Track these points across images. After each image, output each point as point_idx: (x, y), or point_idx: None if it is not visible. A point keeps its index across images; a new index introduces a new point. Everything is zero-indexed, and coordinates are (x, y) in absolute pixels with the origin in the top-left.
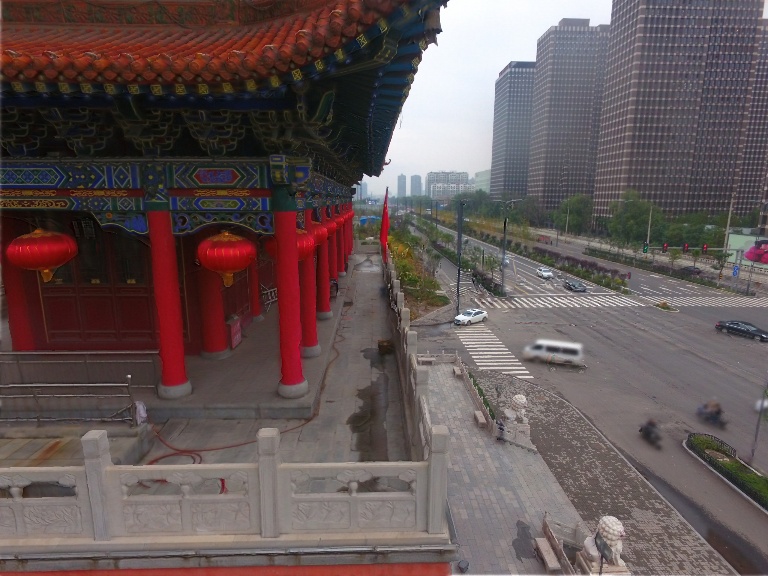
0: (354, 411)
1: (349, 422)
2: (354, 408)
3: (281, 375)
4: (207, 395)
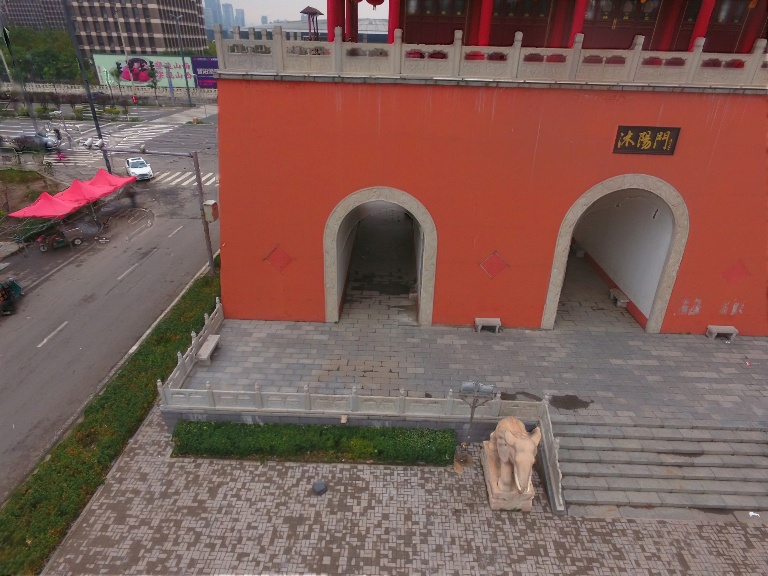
0: None
1: None
2: None
3: None
4: None
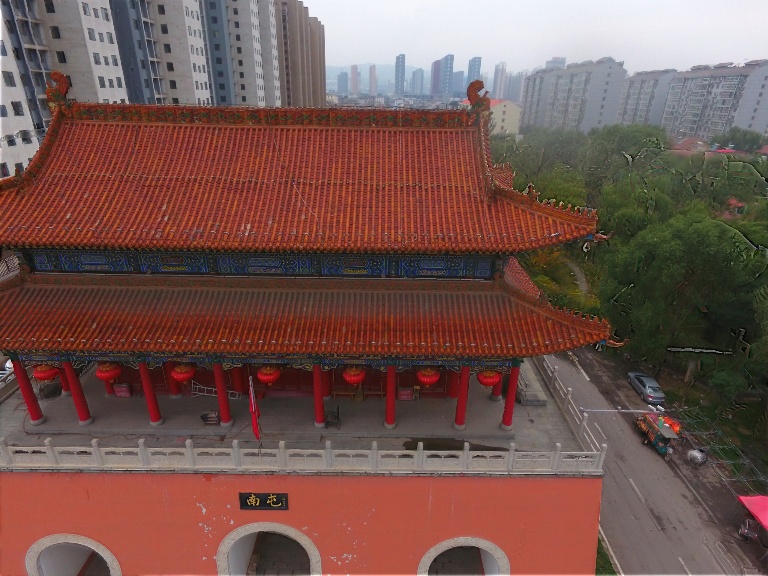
0: None
1: (13, 444)
2: None
3: (64, 416)
4: None
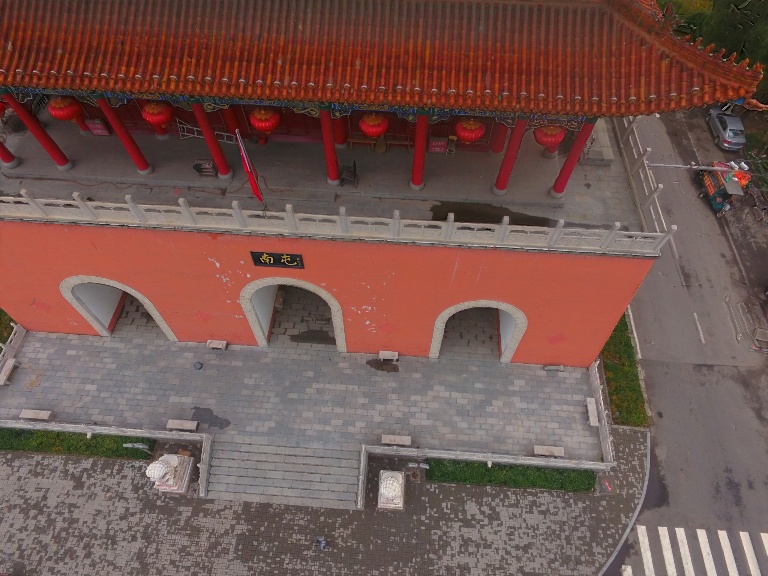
0: (5, 191)
1: None
2: (8, 191)
3: (40, 158)
4: (30, 136)
